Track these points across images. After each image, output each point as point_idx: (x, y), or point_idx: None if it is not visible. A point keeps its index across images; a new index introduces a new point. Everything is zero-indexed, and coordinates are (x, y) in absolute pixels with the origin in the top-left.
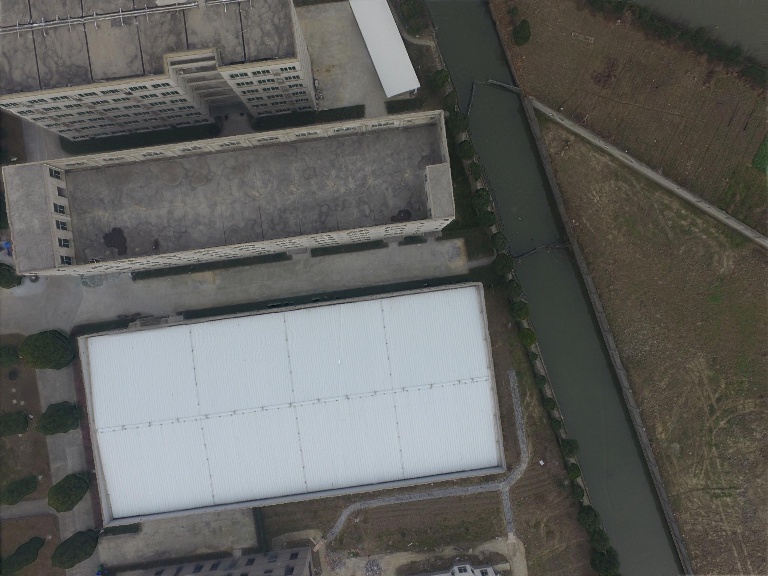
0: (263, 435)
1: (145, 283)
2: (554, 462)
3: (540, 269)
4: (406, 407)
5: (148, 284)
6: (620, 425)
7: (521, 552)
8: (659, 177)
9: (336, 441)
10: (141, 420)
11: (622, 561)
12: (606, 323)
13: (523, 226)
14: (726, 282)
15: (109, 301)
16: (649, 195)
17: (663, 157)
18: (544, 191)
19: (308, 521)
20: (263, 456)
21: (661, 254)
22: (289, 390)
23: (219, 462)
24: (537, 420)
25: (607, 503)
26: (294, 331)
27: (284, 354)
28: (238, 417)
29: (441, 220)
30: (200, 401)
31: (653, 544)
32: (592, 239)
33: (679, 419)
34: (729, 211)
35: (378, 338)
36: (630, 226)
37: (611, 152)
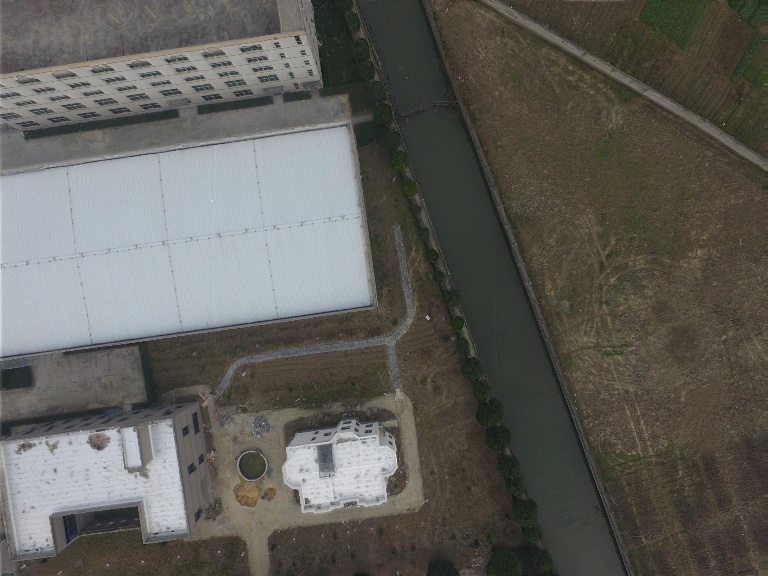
0: (138, 274)
1: (37, 142)
2: (440, 317)
3: (427, 127)
4: (278, 245)
5: (40, 143)
6: (513, 288)
7: (409, 409)
8: (543, 30)
9: (209, 280)
10: (19, 259)
11: (507, 413)
12: (490, 176)
13: (411, 86)
14: (615, 137)
15: (3, 160)
16: (536, 51)
17: (549, 13)
18: (435, 54)
19: (196, 376)
20: (138, 295)
21: (548, 110)
22: (162, 229)
23: (95, 301)
24: (423, 275)
25: (494, 359)
26: (170, 174)
27: (159, 195)
28: (113, 255)
29: (292, 37)
30: (76, 240)
31: (548, 408)
32: (478, 96)
33: (568, 276)
34: (617, 66)
35: (250, 177)
36: (516, 82)
37: (496, 8)
